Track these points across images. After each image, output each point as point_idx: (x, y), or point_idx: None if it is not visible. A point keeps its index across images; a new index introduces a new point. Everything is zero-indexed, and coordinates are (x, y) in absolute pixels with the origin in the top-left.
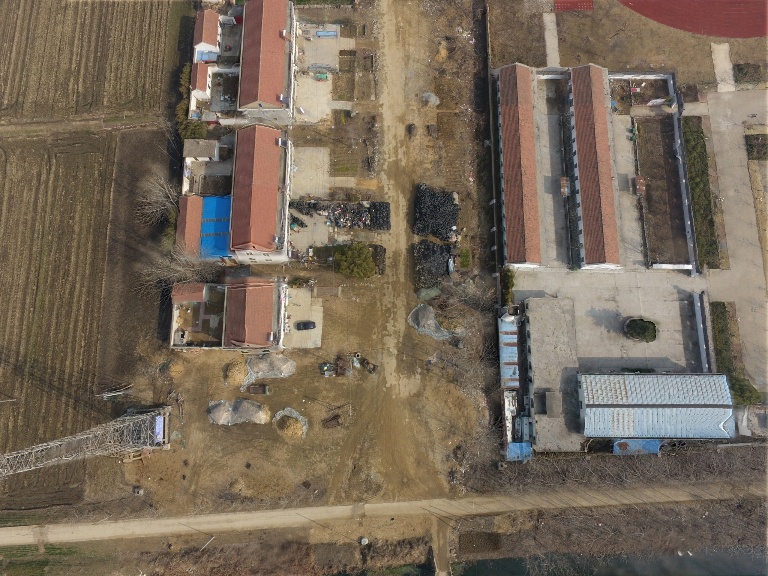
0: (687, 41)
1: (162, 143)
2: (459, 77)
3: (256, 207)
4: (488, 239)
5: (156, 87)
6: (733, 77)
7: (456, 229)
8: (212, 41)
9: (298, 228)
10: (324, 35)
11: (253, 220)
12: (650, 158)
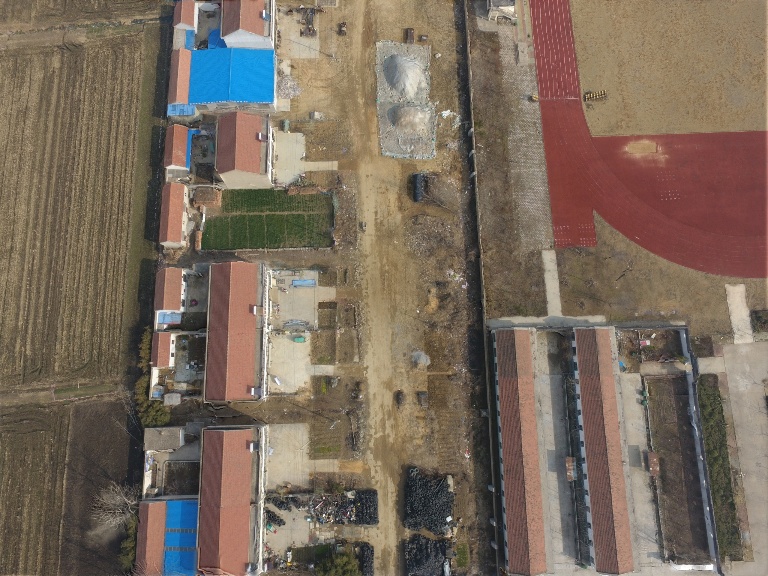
0: (700, 283)
1: (121, 417)
2: (451, 332)
3: (225, 534)
4: (487, 531)
5: (114, 347)
6: (751, 326)
7: (451, 520)
8: (175, 305)
9: (275, 528)
10: (301, 284)
11: (222, 548)
12: (663, 426)
